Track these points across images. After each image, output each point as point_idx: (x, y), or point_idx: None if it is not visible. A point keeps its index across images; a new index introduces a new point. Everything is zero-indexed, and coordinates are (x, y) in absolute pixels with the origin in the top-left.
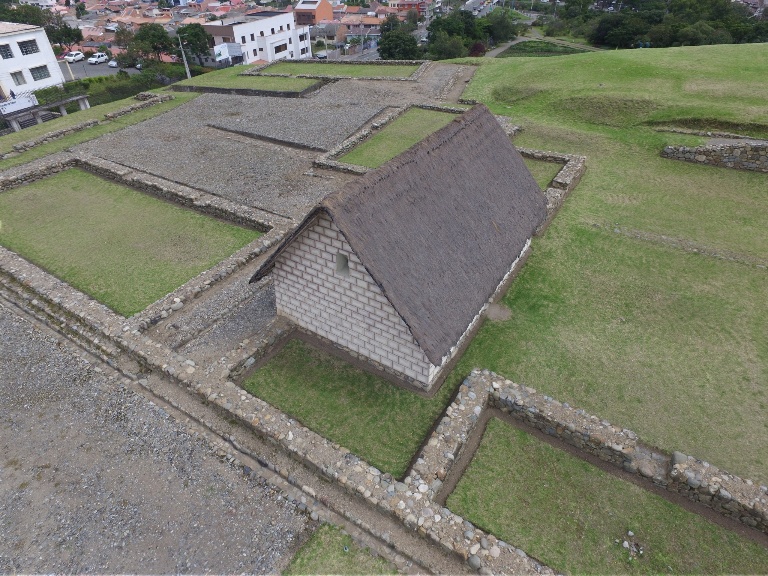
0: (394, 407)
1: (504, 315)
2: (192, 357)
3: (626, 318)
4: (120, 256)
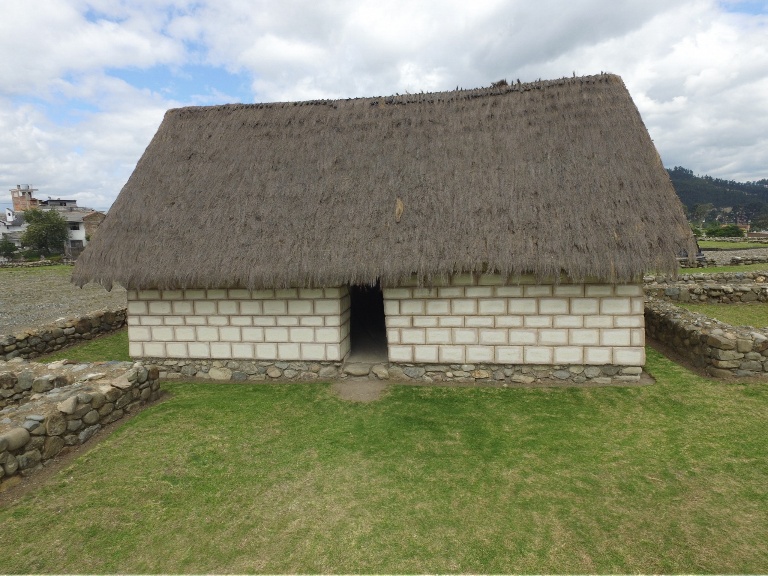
0: None
1: (356, 396)
2: None
3: None
4: None
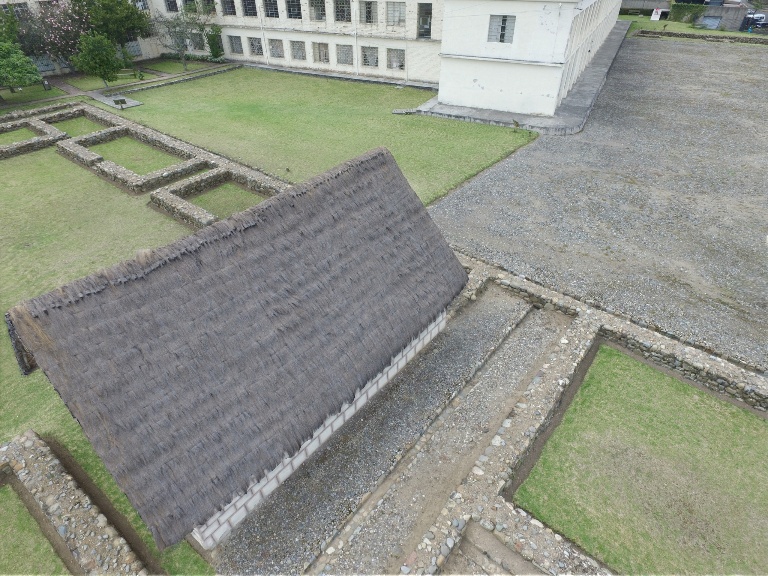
0: None
1: None
2: (512, 299)
3: None
4: (766, 486)
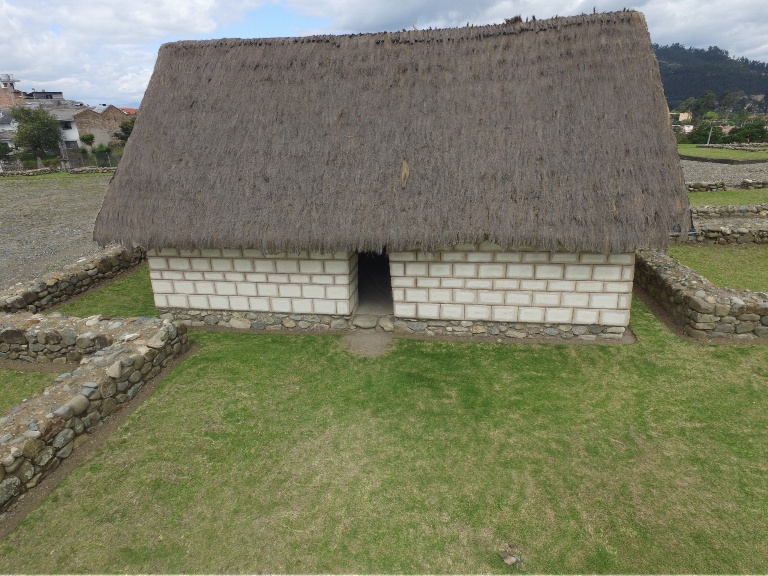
0: (139, 312)
1: (365, 350)
2: None
3: (527, 567)
4: None
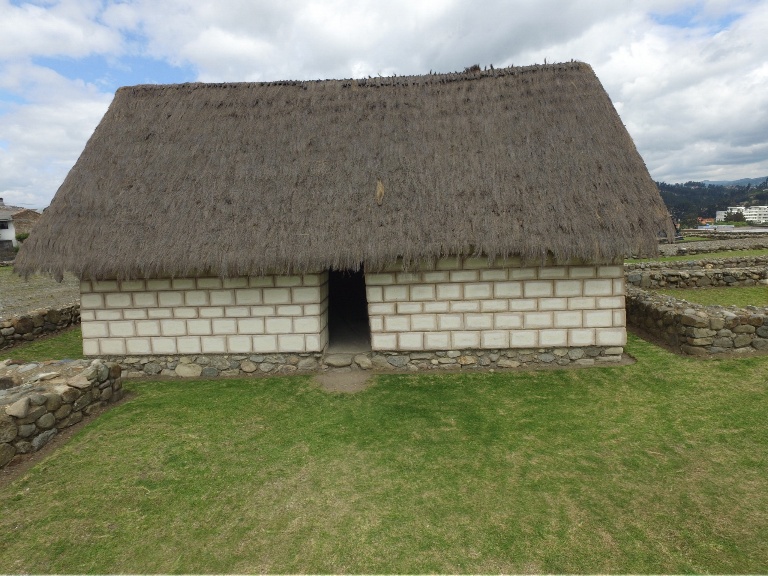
0: None
1: (341, 387)
2: None
3: None
4: None
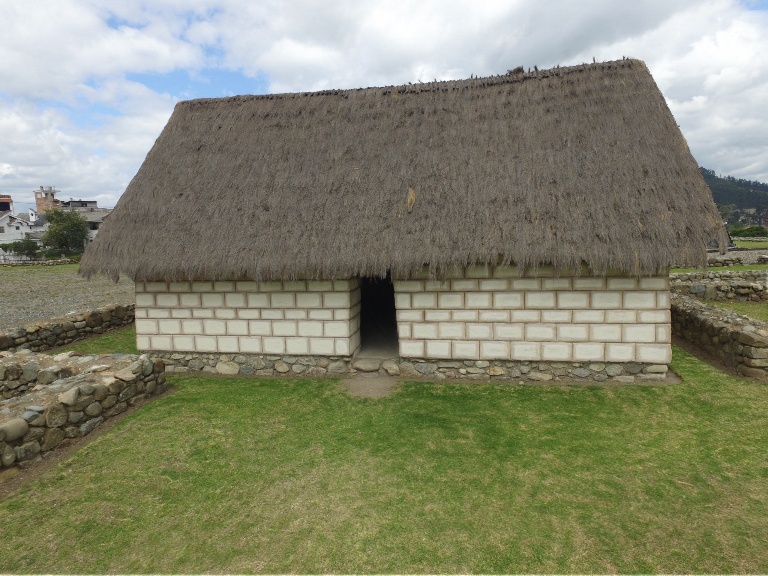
0: None
1: (366, 392)
2: None
3: None
4: None
